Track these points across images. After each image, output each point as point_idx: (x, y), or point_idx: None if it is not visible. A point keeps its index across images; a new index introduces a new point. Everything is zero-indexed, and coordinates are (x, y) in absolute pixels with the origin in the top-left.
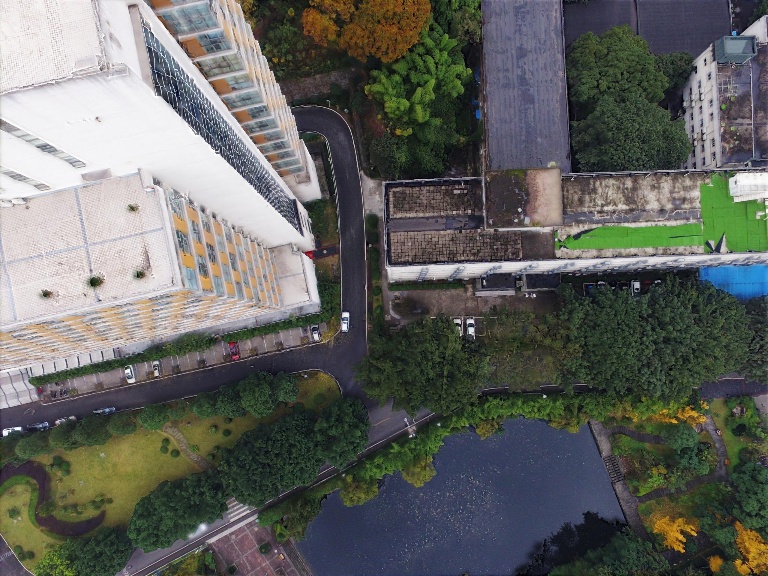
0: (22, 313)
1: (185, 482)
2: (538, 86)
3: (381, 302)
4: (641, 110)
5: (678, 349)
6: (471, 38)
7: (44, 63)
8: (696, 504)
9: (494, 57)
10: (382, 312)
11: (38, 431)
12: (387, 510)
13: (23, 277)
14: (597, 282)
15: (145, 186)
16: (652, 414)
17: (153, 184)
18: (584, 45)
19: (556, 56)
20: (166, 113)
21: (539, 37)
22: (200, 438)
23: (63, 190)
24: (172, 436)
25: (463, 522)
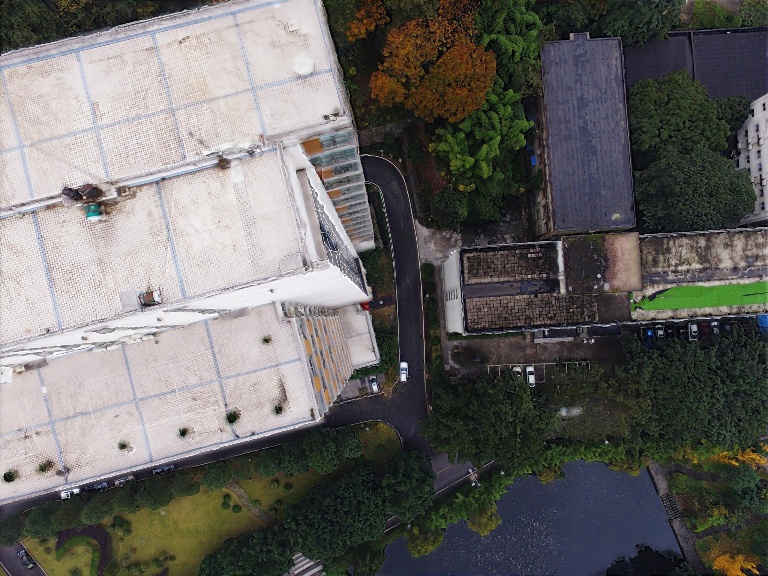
0: (158, 452)
1: (252, 540)
2: (600, 137)
3: (440, 352)
4: (707, 162)
5: (748, 402)
6: (534, 91)
7: (239, 258)
8: (755, 541)
9: (555, 108)
10: (441, 362)
11: (97, 492)
12: (450, 555)
13: (156, 414)
14: (654, 326)
15: (281, 320)
16: (710, 454)
17: (282, 311)
18: (644, 92)
19: (618, 106)
20: (333, 275)
21: (600, 87)
22: (261, 493)
23: (192, 323)
24: (233, 492)
25: (525, 564)
